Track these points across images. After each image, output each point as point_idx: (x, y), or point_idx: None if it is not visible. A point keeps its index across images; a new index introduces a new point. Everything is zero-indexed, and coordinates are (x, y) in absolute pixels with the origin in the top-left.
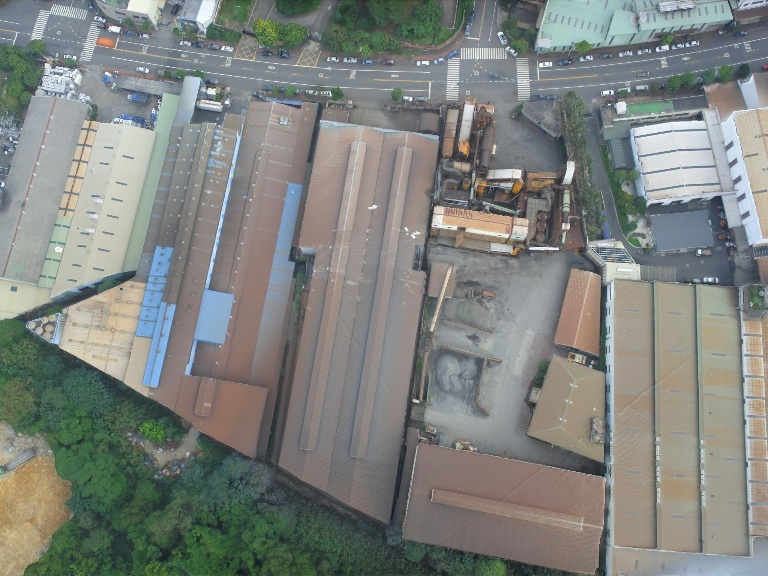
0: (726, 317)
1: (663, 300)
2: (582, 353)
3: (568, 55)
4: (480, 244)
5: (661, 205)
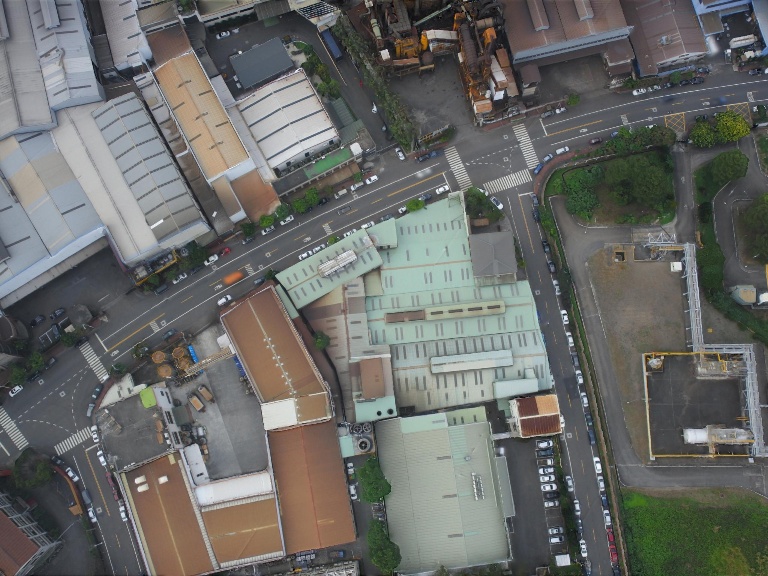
0: None
1: None
2: None
3: None
4: None
5: None
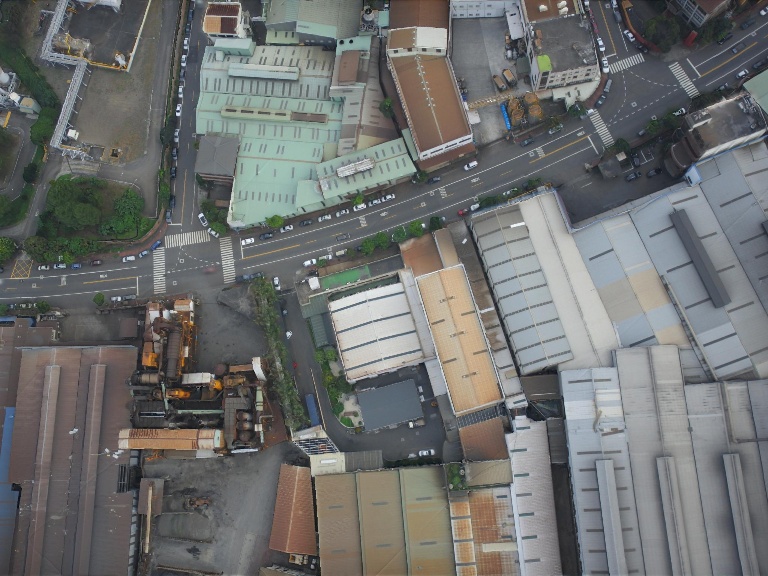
0: (434, 500)
1: (366, 491)
2: (300, 554)
3: (268, 228)
4: (185, 453)
5: (370, 378)
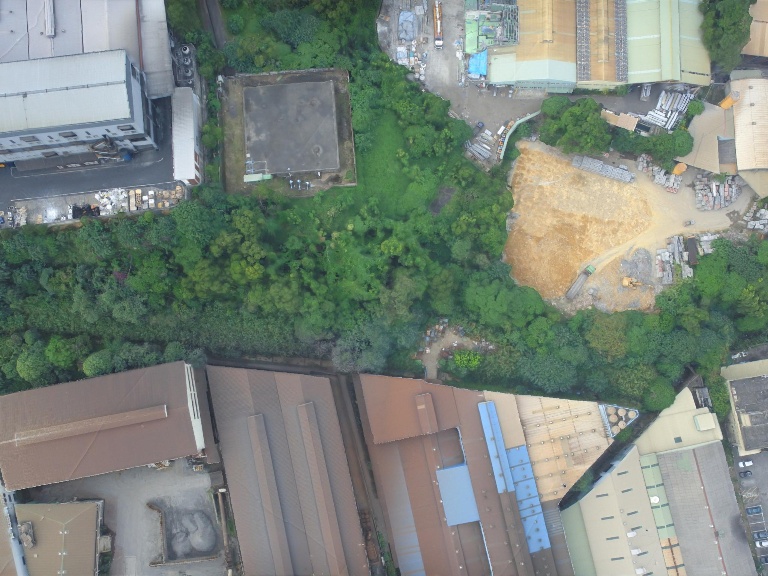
0: None
1: None
2: None
3: None
4: None
5: None
